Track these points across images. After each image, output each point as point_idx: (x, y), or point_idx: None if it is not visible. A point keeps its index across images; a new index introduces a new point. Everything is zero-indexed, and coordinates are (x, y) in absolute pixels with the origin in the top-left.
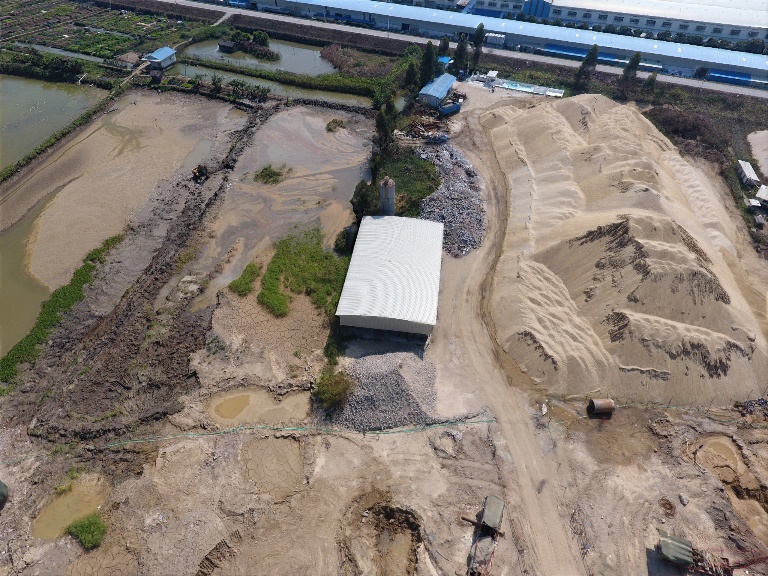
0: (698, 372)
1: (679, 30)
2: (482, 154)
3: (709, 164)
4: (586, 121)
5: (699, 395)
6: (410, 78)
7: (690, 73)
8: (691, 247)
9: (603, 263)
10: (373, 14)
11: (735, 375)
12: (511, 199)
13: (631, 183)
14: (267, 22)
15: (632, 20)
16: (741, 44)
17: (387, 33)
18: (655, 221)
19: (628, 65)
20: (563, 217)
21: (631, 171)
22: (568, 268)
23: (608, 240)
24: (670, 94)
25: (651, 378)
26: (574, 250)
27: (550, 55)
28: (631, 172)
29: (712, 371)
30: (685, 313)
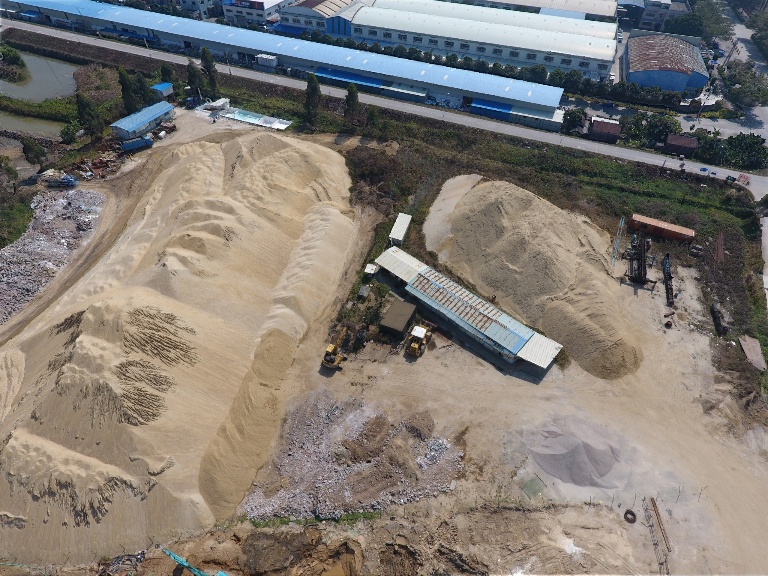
0: (61, 518)
1: (478, 53)
2: (126, 200)
3: (374, 216)
4: (234, 166)
5: (54, 549)
6: (79, 110)
7: (457, 102)
8: (141, 346)
9: (50, 362)
10: (154, 30)
11: (113, 521)
12: (99, 260)
13: (164, 254)
14: (38, 37)
15: (431, 41)
16: (522, 71)
17: (156, 52)
18: (110, 312)
19: (347, 97)
20: (92, 292)
21: (182, 237)
22: (34, 363)
23: (72, 331)
24: (407, 128)
25: (3, 525)
26: (50, 340)
27: (320, 79)
28: (182, 238)
29: (78, 517)
30: (79, 438)
